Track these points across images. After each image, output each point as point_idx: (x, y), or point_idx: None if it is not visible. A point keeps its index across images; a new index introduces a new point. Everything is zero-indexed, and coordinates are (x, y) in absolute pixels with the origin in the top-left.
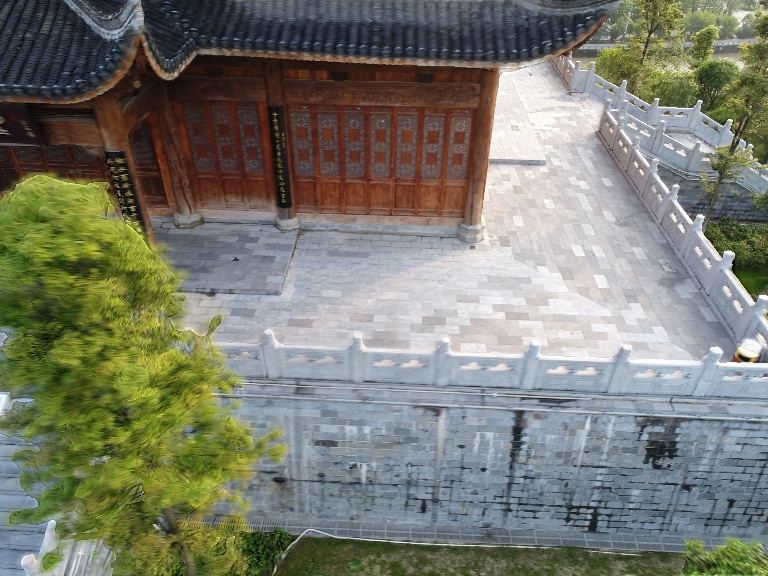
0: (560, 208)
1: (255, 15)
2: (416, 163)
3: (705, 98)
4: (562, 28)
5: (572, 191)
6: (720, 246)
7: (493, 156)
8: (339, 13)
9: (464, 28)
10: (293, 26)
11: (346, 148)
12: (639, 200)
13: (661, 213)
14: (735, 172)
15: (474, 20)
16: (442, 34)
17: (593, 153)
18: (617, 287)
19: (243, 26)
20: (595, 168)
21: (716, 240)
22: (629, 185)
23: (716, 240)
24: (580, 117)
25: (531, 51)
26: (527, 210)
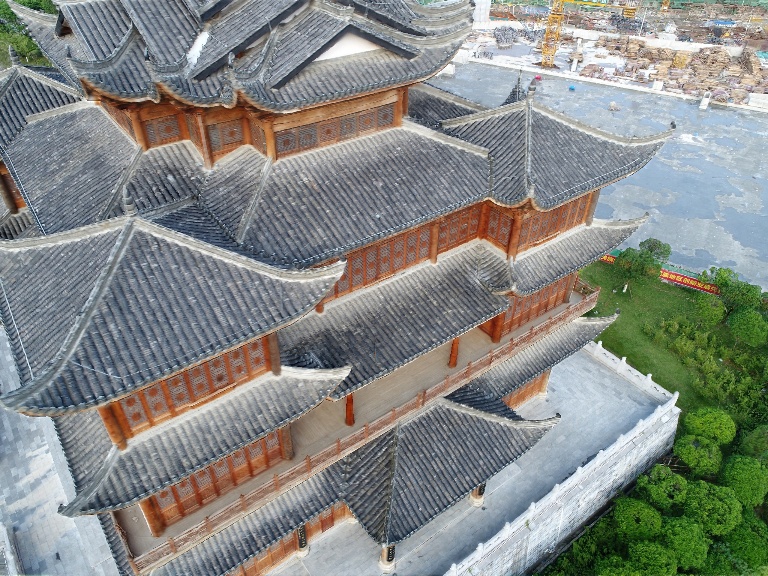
0: None
1: None
2: None
3: None
4: None
5: None
6: None
7: None
8: None
9: None
10: None
11: None
12: None
13: None
14: None
15: None
16: None
17: (2, 437)
18: (3, 344)
19: None
20: (3, 420)
21: None
22: None
23: None
24: (7, 486)
25: None
26: None
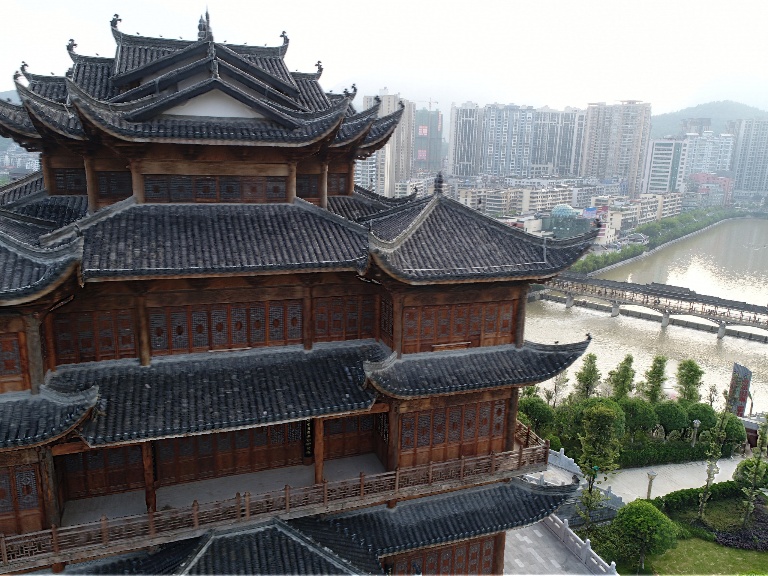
0: (527, 565)
1: (395, 525)
2: (465, 573)
3: (532, 422)
4: (548, 502)
5: (525, 547)
6: (600, 550)
7: None
8: (436, 512)
9: (500, 507)
10: (418, 528)
11: (426, 575)
12: (563, 545)
13: (584, 556)
14: (596, 505)
15: (502, 501)
16: (491, 514)
17: None
18: None
19: (393, 535)
20: None
21: (596, 547)
22: (551, 533)
23: (596, 547)
24: None
25: (538, 517)
26: (511, 573)
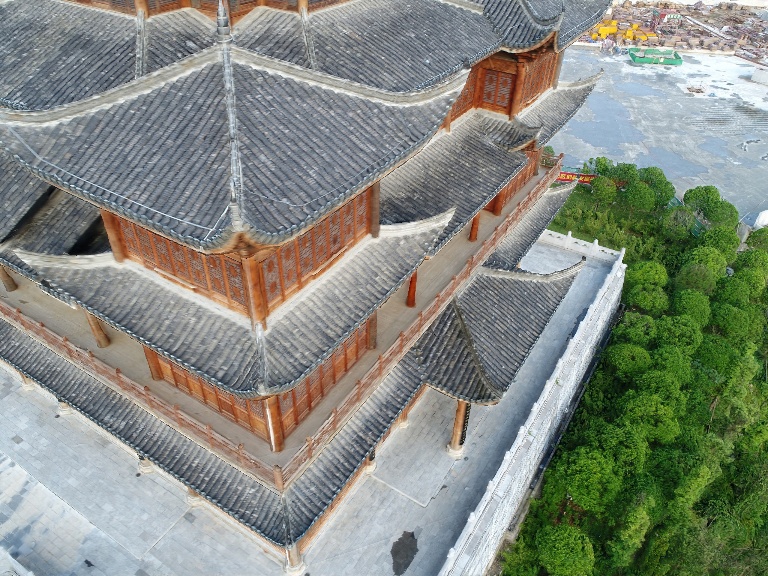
0: None
1: None
2: None
3: None
4: None
5: None
6: None
7: (8, 398)
8: None
9: None
10: None
11: None
12: None
13: None
14: None
15: None
16: None
17: None
18: None
19: None
20: None
21: None
22: None
23: None
24: None
25: None
26: None
